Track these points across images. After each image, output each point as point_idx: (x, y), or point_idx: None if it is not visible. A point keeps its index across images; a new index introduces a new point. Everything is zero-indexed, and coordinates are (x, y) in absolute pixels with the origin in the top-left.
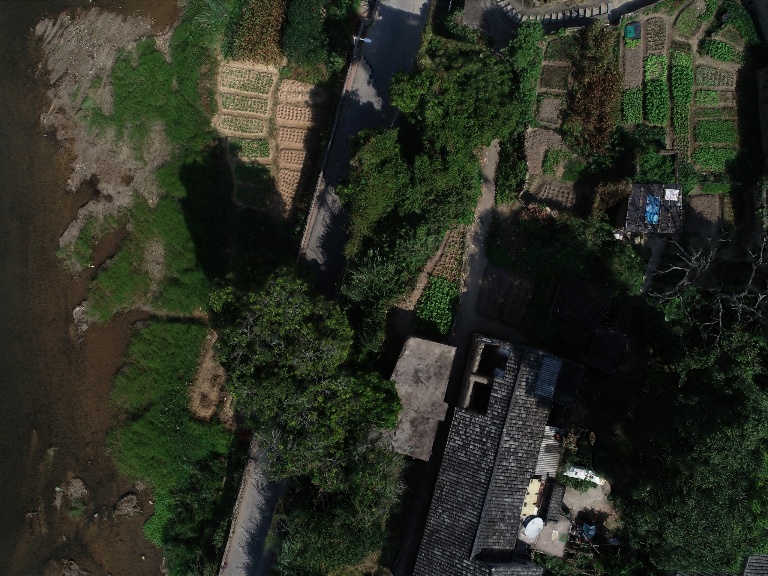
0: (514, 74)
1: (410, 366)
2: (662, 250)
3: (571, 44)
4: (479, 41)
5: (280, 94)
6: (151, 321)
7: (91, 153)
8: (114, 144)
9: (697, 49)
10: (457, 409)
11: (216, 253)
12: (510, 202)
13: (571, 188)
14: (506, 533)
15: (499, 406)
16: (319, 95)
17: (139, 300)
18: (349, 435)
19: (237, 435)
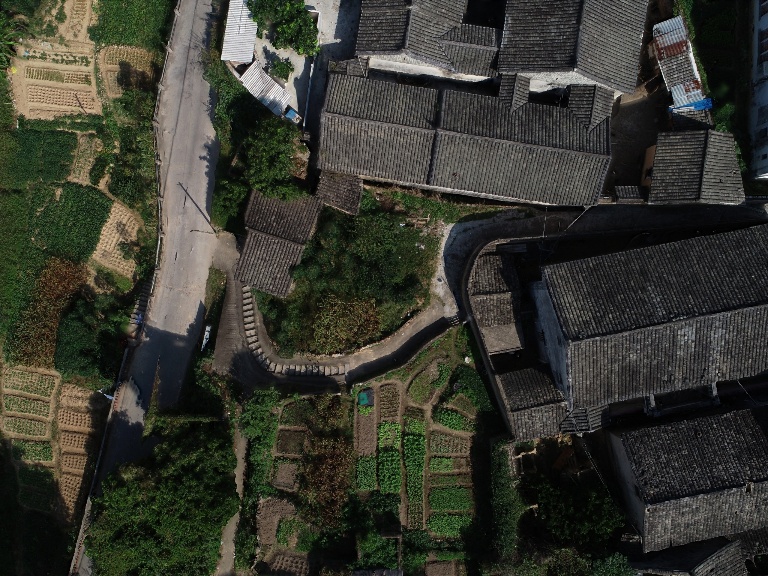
0: None
1: None
2: None
3: (307, 408)
4: (225, 391)
5: (61, 398)
6: None
7: None
8: None
9: (431, 415)
10: None
11: (2, 554)
12: (247, 569)
13: (306, 557)
14: None
15: None
16: (98, 401)
17: None
18: None
19: None
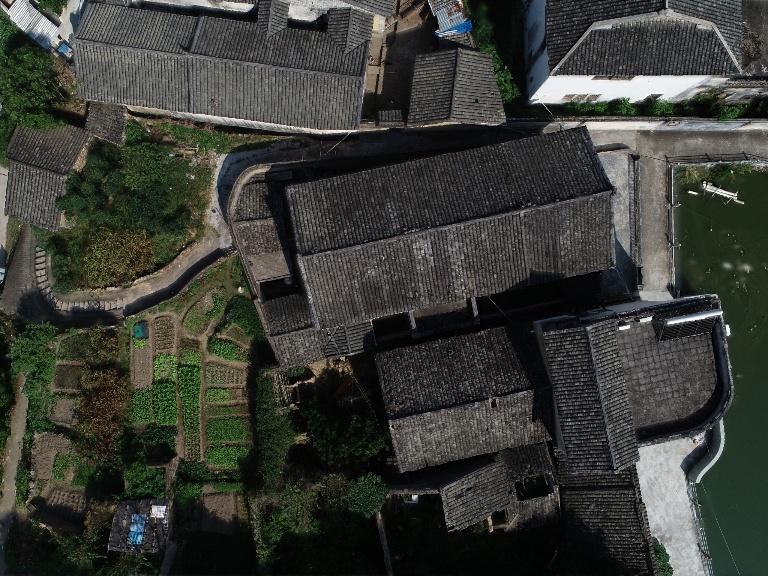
0: None
1: None
2: (175, 552)
3: (83, 343)
4: (11, 330)
5: None
6: None
7: None
8: None
9: (207, 346)
10: None
11: None
12: None
13: (83, 491)
14: None
15: None
16: None
17: None
18: None
19: None
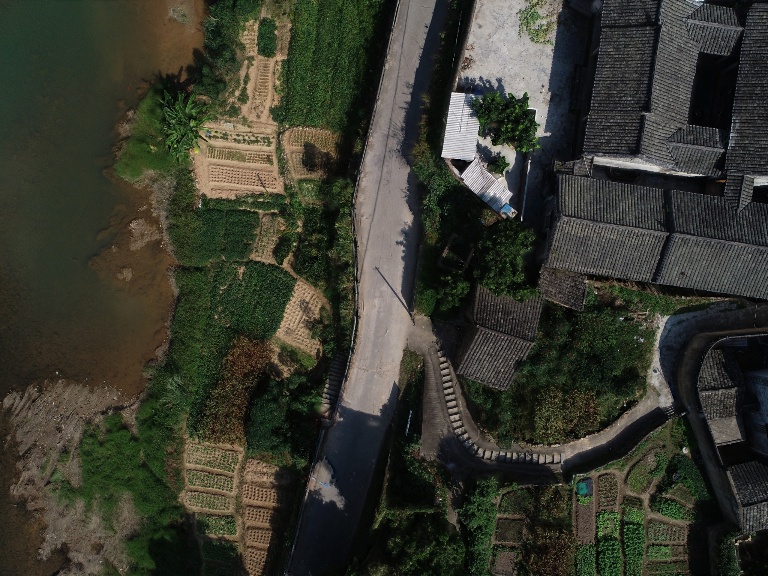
0: (469, 529)
1: None
2: None
3: (525, 497)
4: (436, 477)
5: (245, 474)
6: None
7: (61, 523)
8: (83, 514)
9: (648, 503)
10: None
11: None
12: None
13: None
14: None
15: None
16: (284, 477)
17: None
18: None
19: None
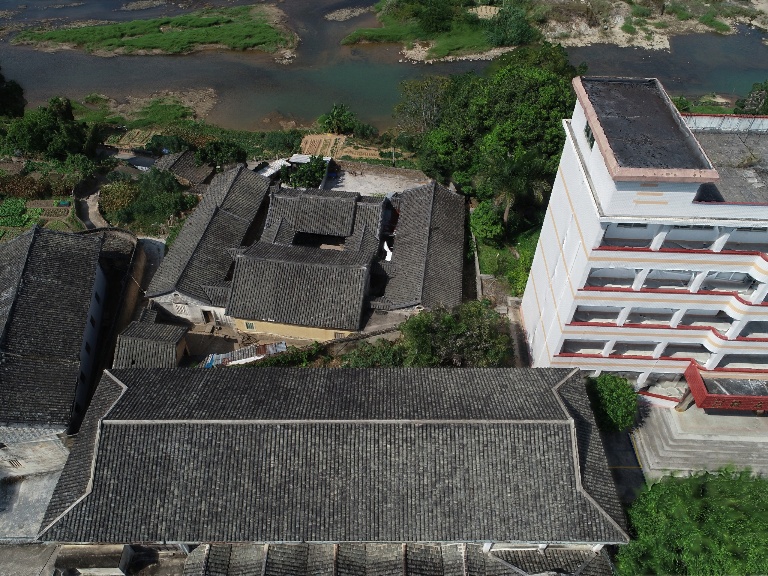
0: None
1: None
2: None
3: None
4: None
5: None
6: None
7: None
8: None
9: None
10: None
11: None
12: None
13: None
14: None
15: None
16: None
17: None
18: None
19: None
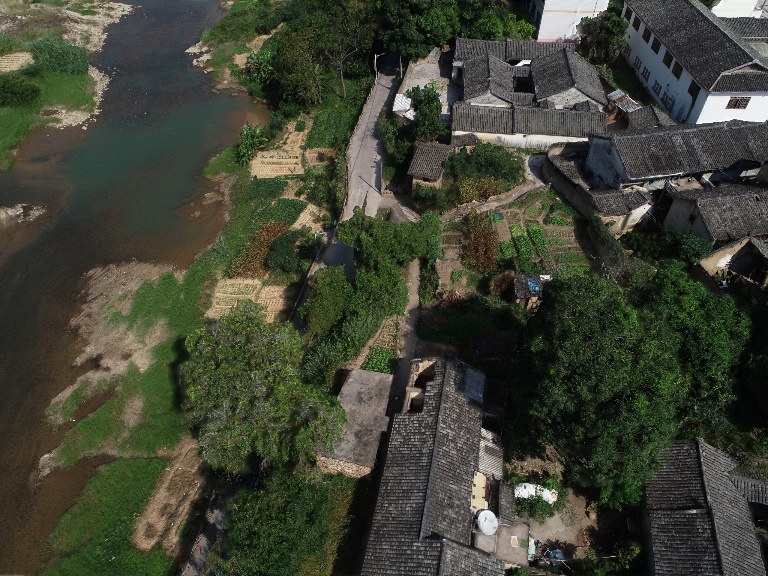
0: None
1: (354, 390)
2: None
3: (460, 225)
4: None
5: (261, 294)
6: (115, 461)
7: (103, 340)
8: (123, 333)
9: (543, 223)
10: (397, 414)
11: None
12: (431, 301)
13: (475, 290)
14: (457, 523)
15: (433, 401)
16: (290, 291)
17: (108, 444)
18: (294, 412)
19: (177, 560)
